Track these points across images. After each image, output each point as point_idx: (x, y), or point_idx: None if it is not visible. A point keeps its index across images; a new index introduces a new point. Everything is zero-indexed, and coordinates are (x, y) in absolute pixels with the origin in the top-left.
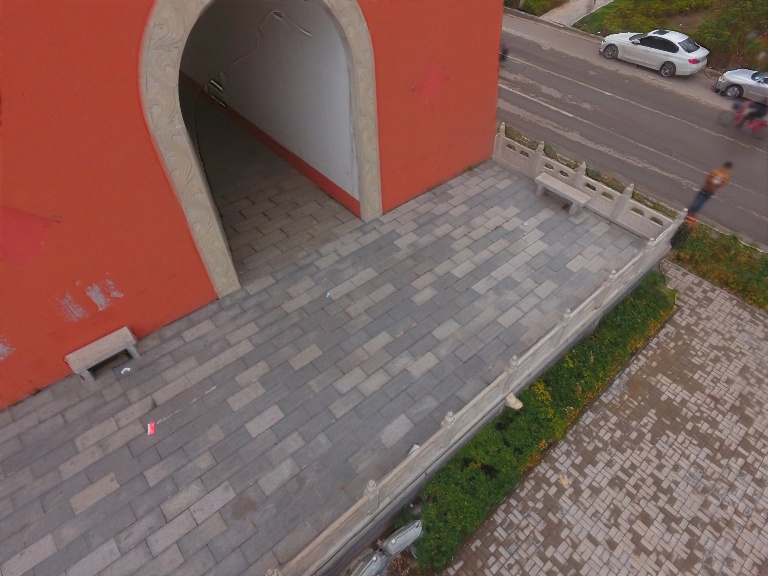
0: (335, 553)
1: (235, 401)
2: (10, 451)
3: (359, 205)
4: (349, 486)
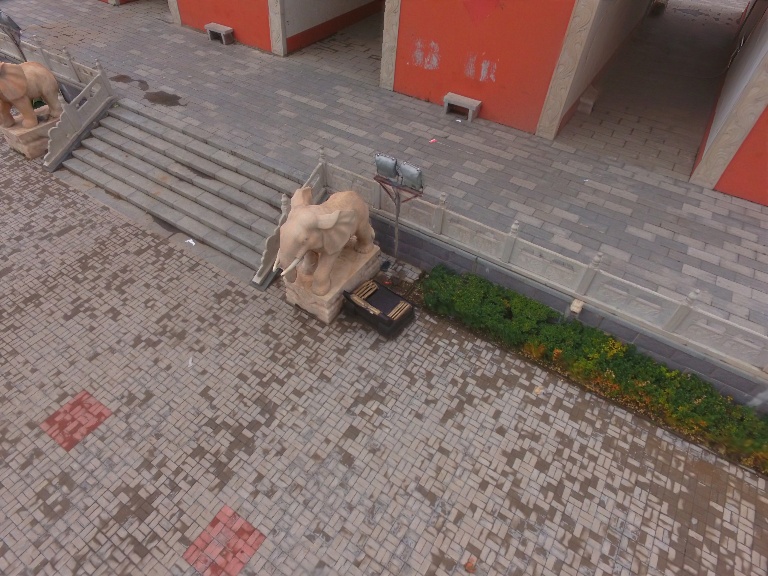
0: (405, 225)
1: (469, 163)
2: (396, 107)
3: (699, 163)
4: None
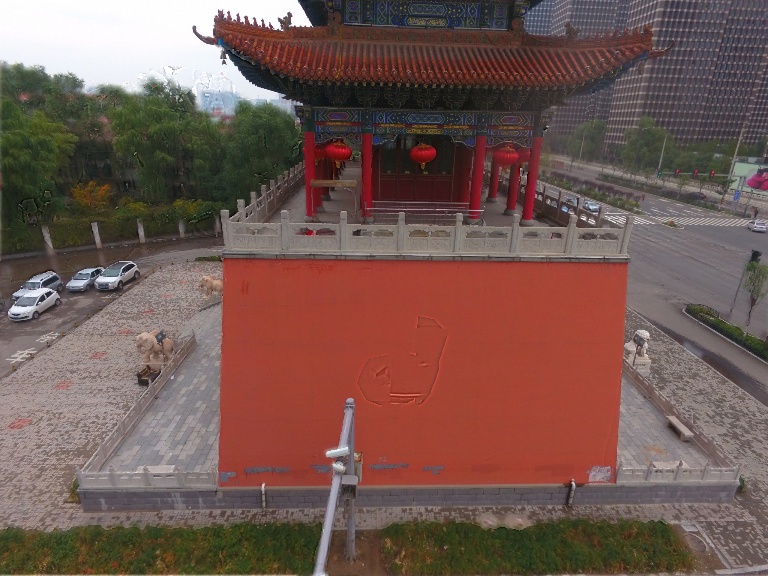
0: None
1: None
2: None
3: None
4: (185, 367)
